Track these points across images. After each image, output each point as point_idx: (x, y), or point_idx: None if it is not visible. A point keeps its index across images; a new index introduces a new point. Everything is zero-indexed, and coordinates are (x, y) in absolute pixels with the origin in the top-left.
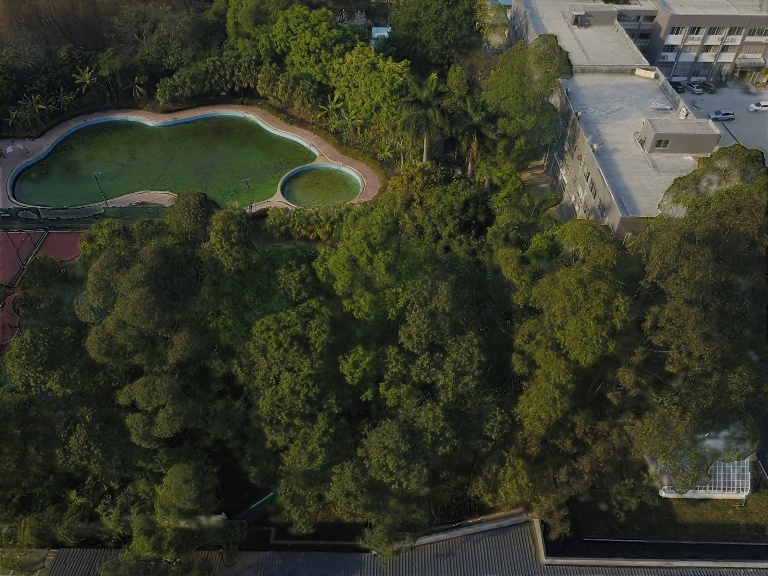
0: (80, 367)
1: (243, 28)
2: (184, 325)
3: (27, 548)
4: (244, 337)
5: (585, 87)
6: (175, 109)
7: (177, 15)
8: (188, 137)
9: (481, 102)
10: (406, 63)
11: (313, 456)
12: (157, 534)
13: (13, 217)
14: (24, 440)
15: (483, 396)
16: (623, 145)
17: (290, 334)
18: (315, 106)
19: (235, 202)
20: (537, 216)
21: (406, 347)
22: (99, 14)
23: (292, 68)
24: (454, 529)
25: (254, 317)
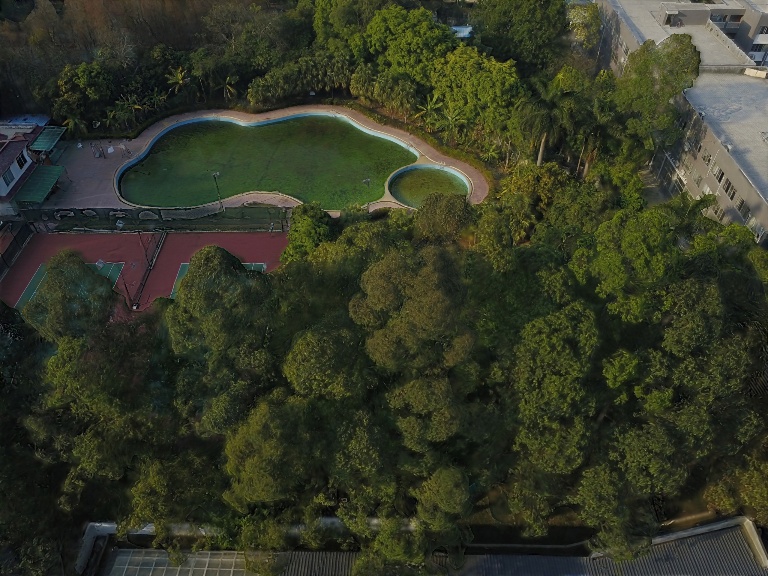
0: (358, 370)
1: (334, 28)
2: (464, 328)
3: (273, 551)
4: (512, 340)
5: (697, 87)
6: (266, 109)
7: (268, 15)
8: (283, 137)
9: (609, 102)
10: (512, 63)
11: (571, 460)
12: (405, 538)
13: (134, 218)
14: (310, 444)
15: (734, 399)
16: (753, 145)
17: (562, 337)
18: (414, 106)
19: (355, 203)
20: (692, 217)
21: (669, 350)
22: (188, 14)
23: (388, 68)
24: (670, 533)
25: (521, 320)
